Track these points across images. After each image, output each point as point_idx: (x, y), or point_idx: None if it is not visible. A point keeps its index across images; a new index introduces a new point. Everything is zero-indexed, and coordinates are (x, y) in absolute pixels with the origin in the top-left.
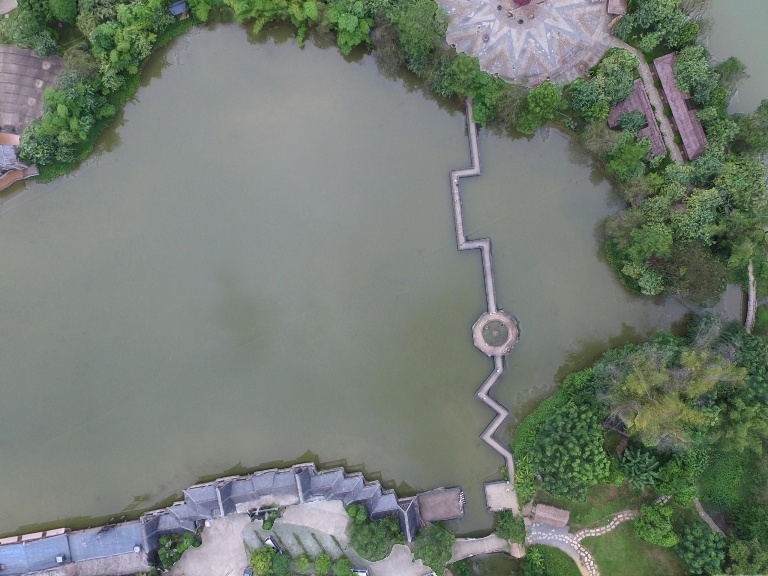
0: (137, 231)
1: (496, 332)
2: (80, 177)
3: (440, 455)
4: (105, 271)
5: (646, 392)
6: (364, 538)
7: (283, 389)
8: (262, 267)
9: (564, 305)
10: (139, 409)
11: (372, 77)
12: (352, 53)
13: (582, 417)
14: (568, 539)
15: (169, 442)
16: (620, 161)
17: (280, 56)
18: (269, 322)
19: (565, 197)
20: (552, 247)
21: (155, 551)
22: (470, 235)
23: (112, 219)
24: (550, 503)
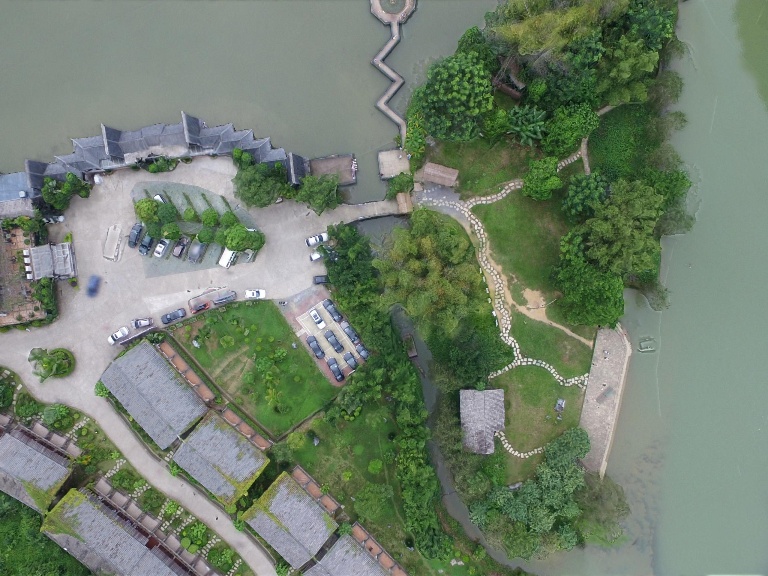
0: None
1: None
2: None
3: (334, 122)
4: None
5: (525, 8)
6: (247, 173)
7: (179, 53)
8: None
9: None
10: (34, 69)
11: None
12: None
13: (468, 57)
14: (459, 206)
15: (63, 103)
16: None
17: None
18: None
19: None
20: None
21: (41, 197)
22: None
23: None
24: None
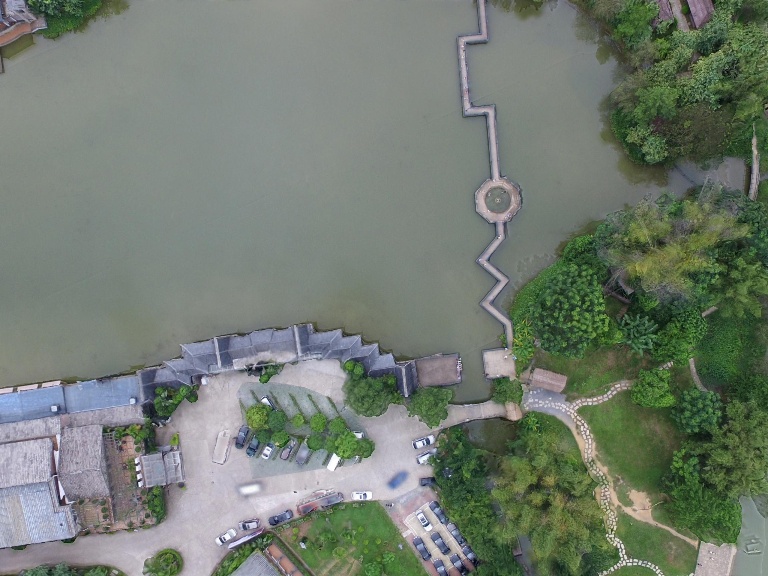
0: (143, 89)
1: (499, 199)
2: (88, 33)
3: (439, 321)
4: (110, 128)
5: (648, 240)
6: (361, 390)
7: (284, 251)
8: (267, 128)
9: (567, 175)
10: (139, 267)
11: None
12: None
13: (583, 274)
14: (565, 407)
15: (168, 301)
16: (627, 24)
17: None
18: (272, 183)
19: (571, 67)
20: (557, 116)
21: (150, 404)
22: (475, 102)
23: (118, 76)
24: (548, 369)
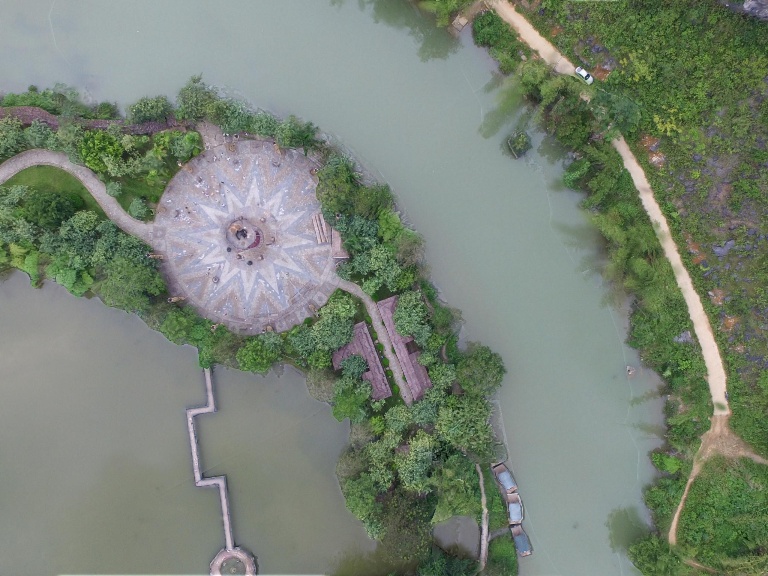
0: None
1: (233, 569)
2: None
3: None
4: None
5: None
6: None
7: None
8: (1, 506)
9: (302, 539)
10: None
11: (113, 311)
12: (86, 294)
13: None
14: None
15: None
16: None
17: (18, 295)
18: (8, 562)
19: (301, 432)
20: (288, 482)
21: None
22: (207, 472)
23: None
24: None
